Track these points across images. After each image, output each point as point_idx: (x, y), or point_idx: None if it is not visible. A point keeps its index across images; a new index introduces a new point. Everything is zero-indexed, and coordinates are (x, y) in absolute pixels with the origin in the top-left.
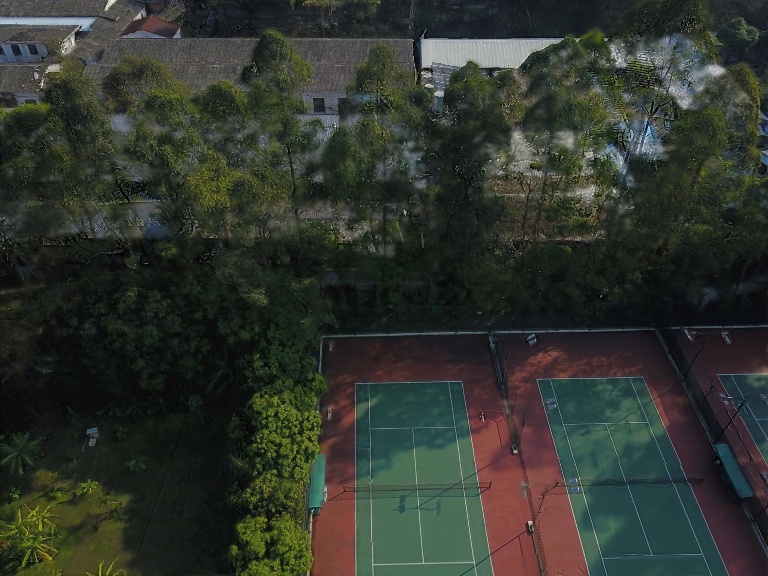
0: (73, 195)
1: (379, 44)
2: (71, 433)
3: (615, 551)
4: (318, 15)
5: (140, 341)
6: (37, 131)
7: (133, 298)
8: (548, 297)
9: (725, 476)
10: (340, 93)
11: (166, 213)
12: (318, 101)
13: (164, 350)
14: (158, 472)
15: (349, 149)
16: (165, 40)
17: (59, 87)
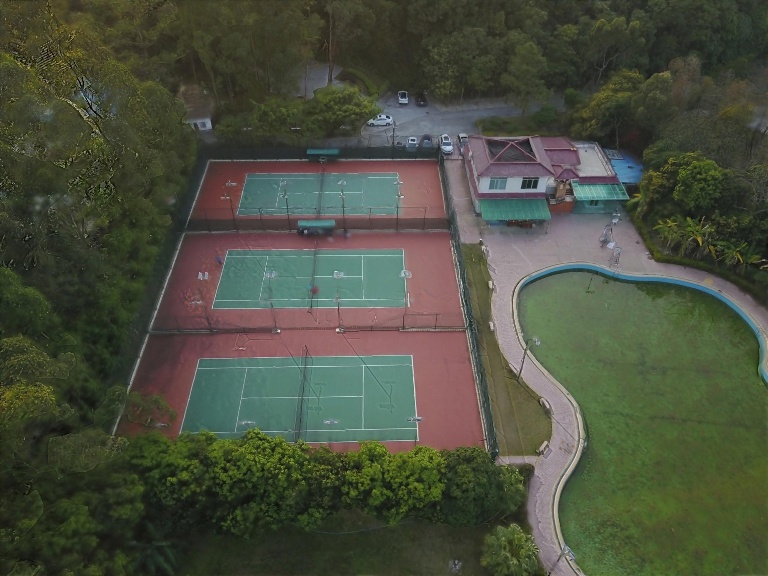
0: None
1: None
2: None
3: (359, 292)
4: None
5: None
6: None
7: None
8: (141, 272)
9: (315, 232)
10: None
11: None
12: None
13: None
14: None
15: (2, 270)
16: None
17: None
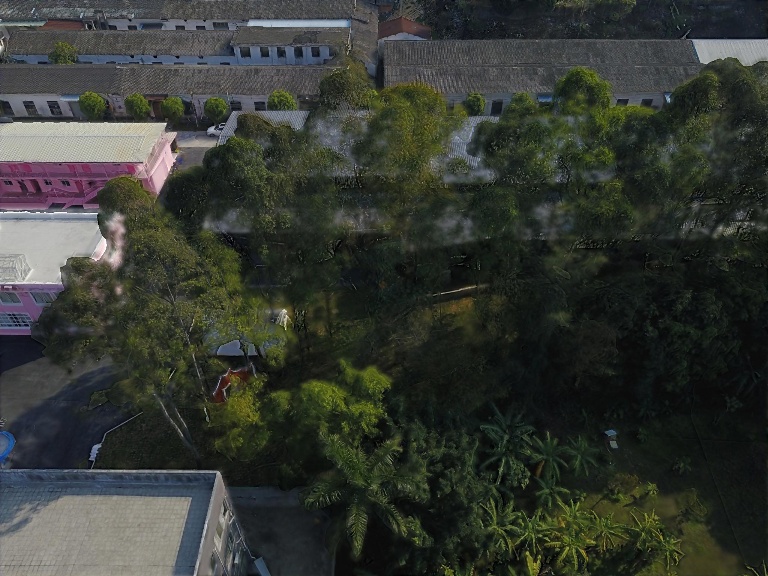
0: (694, 197)
1: (658, 45)
2: (587, 436)
3: None
4: (567, 16)
5: (696, 343)
6: (669, 133)
7: (689, 300)
8: None
9: None
10: (647, 94)
11: (713, 215)
12: (621, 102)
13: (706, 352)
14: (702, 474)
15: None
16: (442, 42)
17: (717, 89)
